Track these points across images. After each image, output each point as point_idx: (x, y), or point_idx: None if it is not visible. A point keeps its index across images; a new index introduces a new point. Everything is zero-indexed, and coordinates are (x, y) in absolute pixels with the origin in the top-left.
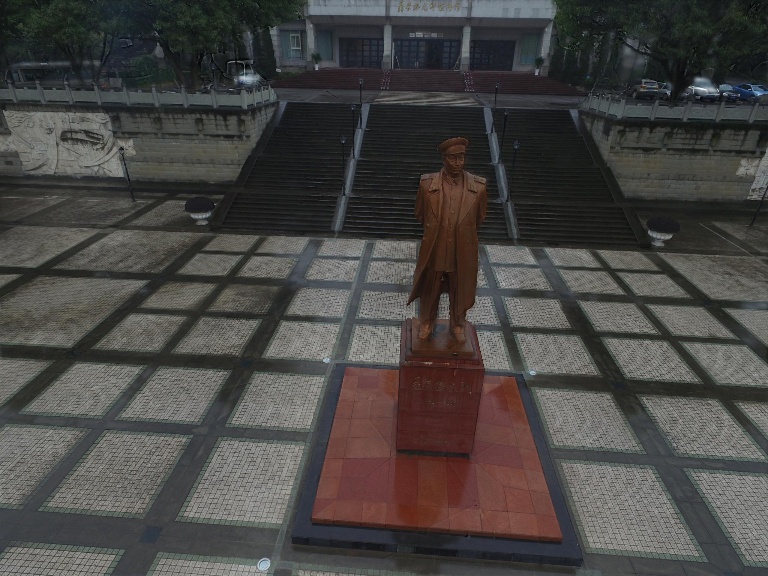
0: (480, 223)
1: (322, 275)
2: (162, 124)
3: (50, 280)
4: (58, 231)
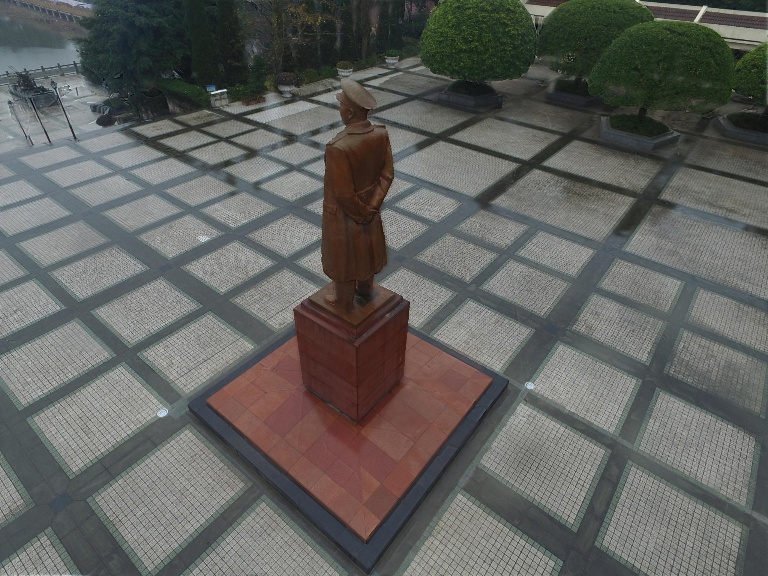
0: None
1: None
2: None
3: None
4: None
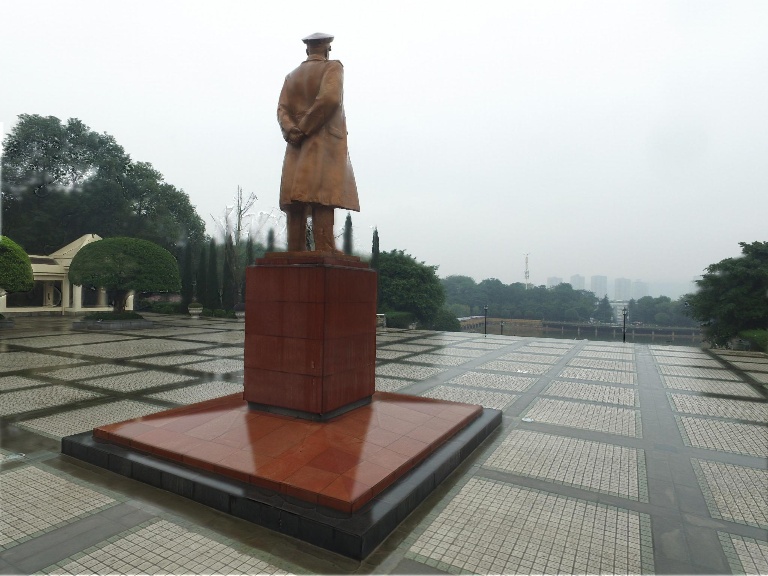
0: None
1: None
2: None
3: None
4: None
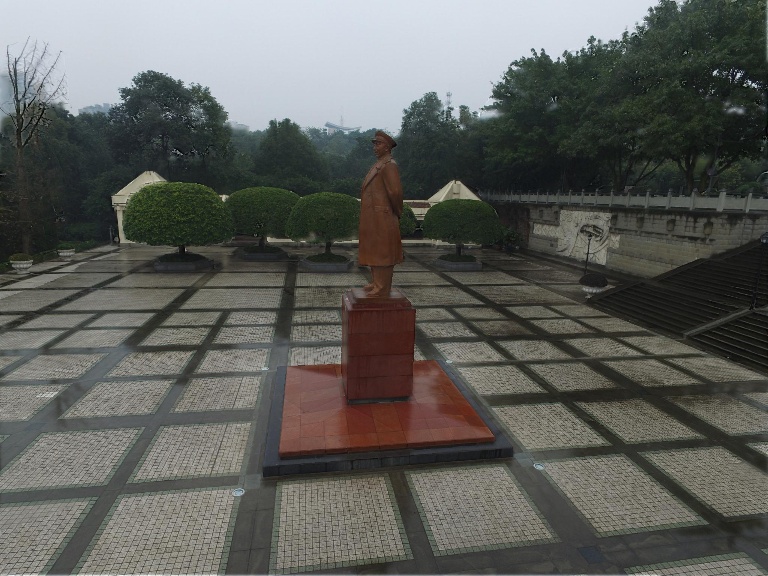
0: (392, 198)
1: (581, 344)
2: (644, 223)
3: (455, 289)
4: (508, 277)
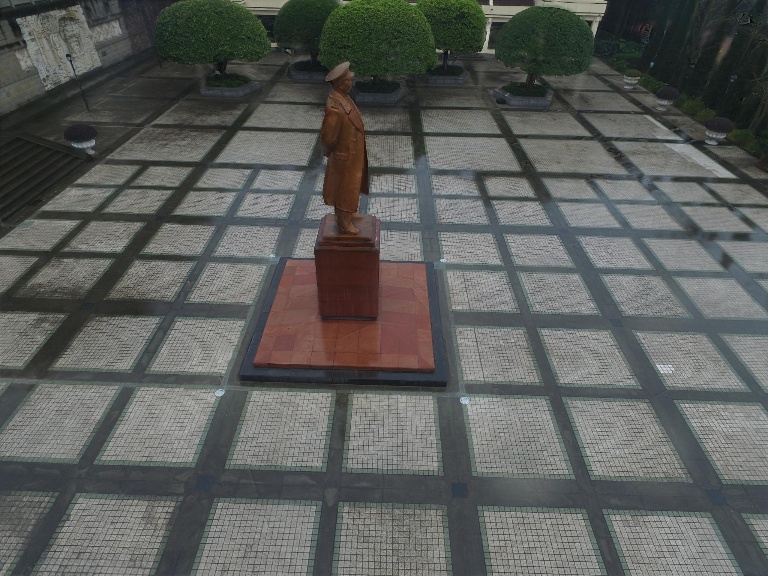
0: None
1: None
2: None
3: None
4: None
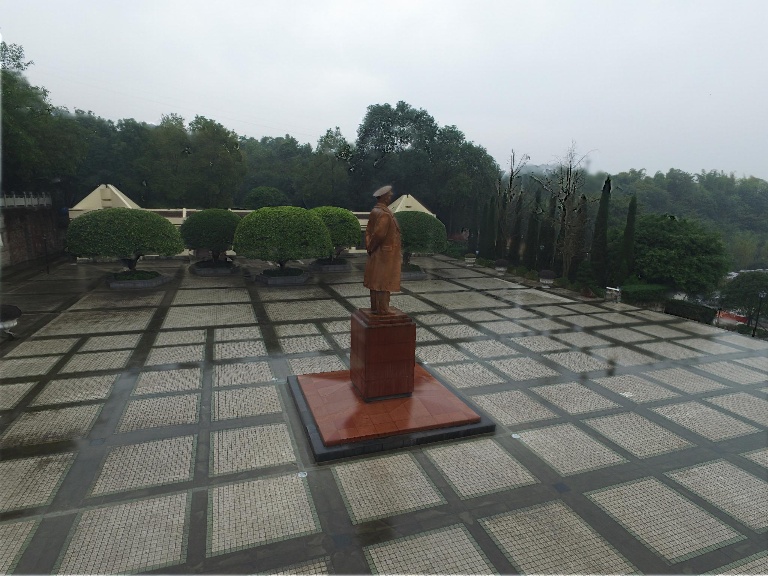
0: None
1: None
2: None
3: None
4: None
